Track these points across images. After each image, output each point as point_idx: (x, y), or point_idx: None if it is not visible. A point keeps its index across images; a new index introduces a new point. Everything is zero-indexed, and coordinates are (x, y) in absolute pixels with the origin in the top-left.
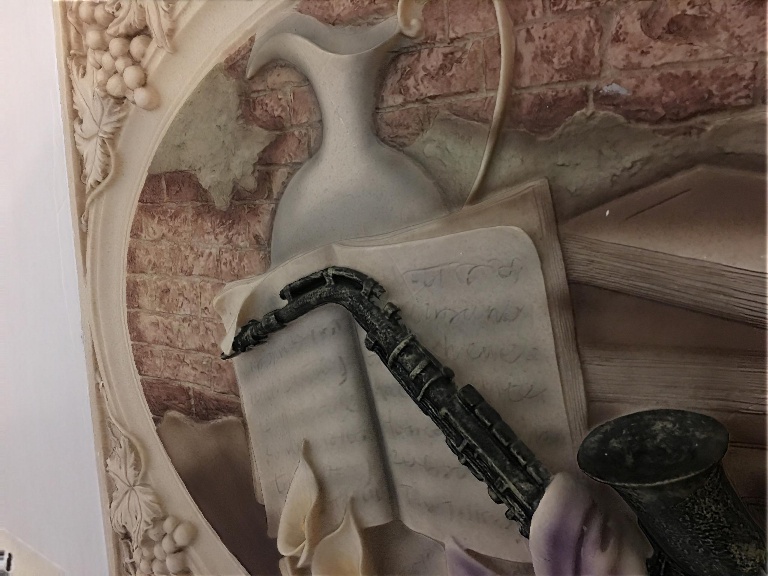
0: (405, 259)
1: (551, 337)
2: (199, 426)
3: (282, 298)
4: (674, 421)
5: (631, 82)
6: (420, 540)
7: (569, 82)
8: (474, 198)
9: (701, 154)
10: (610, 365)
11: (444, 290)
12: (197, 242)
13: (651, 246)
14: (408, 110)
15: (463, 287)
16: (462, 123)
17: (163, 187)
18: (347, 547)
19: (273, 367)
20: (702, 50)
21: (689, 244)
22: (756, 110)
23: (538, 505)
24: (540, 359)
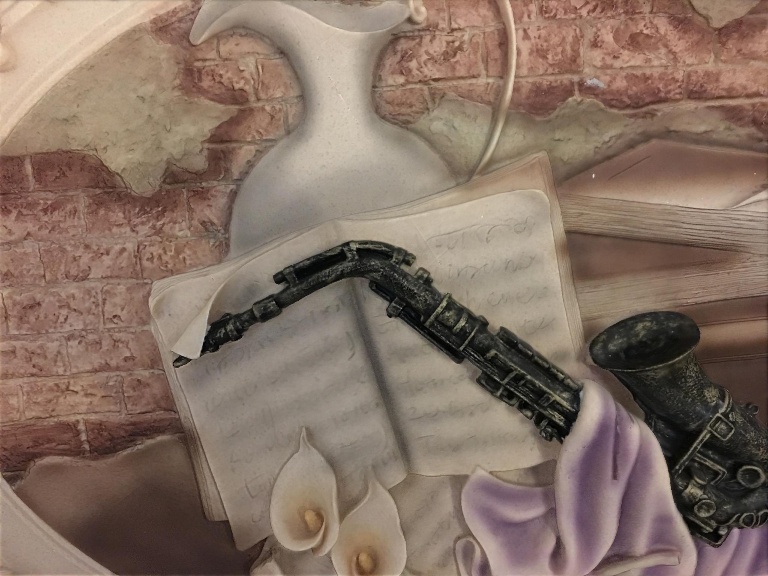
0: (430, 226)
1: (558, 276)
2: (100, 463)
3: (278, 282)
4: (651, 320)
5: (607, 78)
6: (424, 486)
7: (559, 75)
8: (483, 169)
9: (654, 132)
10: (598, 291)
11: (466, 250)
12: (97, 238)
13: (630, 198)
14: (411, 90)
15: (483, 246)
16: (468, 104)
17: (27, 172)
18: (364, 517)
19: (248, 362)
20: (654, 59)
21: (656, 194)
22: (684, 102)
23: (581, 406)
24: (550, 295)
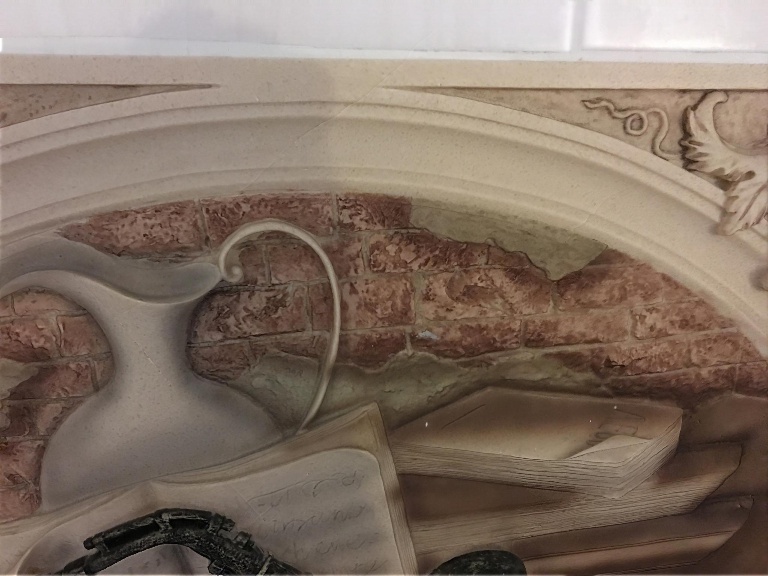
0: (251, 489)
1: (390, 522)
2: None
3: (88, 549)
4: (484, 560)
5: (440, 330)
6: None
7: (389, 327)
8: (310, 422)
9: (490, 380)
10: (432, 529)
11: (291, 506)
12: None
13: (463, 447)
14: (230, 347)
15: (310, 500)
16: (292, 359)
17: None
18: None
19: None
20: (489, 311)
21: (489, 444)
22: (521, 350)
23: None
24: (381, 540)
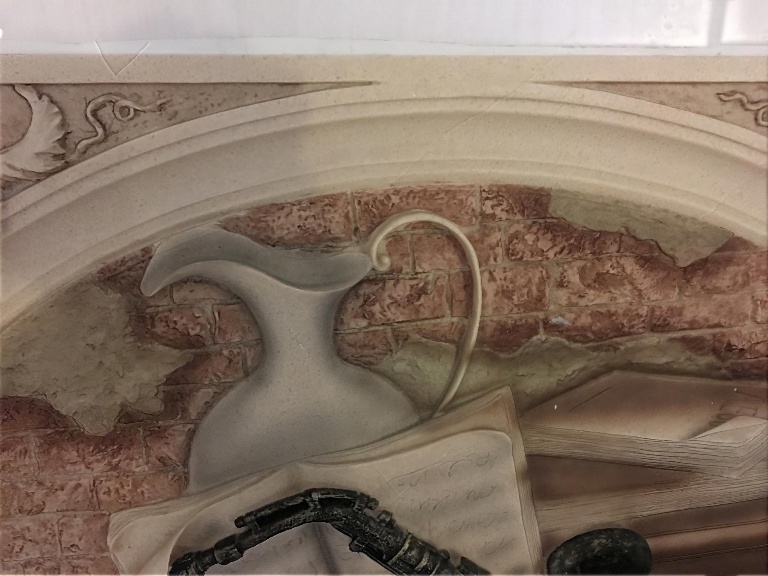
0: (393, 469)
1: (518, 501)
2: None
3: (239, 527)
4: (607, 538)
5: (571, 316)
6: None
7: (524, 313)
8: (447, 405)
9: (617, 364)
10: (557, 508)
11: (428, 486)
12: (50, 475)
13: (590, 429)
14: (374, 333)
15: (445, 480)
16: (432, 344)
17: None
18: None
19: None
20: (619, 297)
21: (616, 425)
22: (647, 334)
23: None
24: (510, 519)
